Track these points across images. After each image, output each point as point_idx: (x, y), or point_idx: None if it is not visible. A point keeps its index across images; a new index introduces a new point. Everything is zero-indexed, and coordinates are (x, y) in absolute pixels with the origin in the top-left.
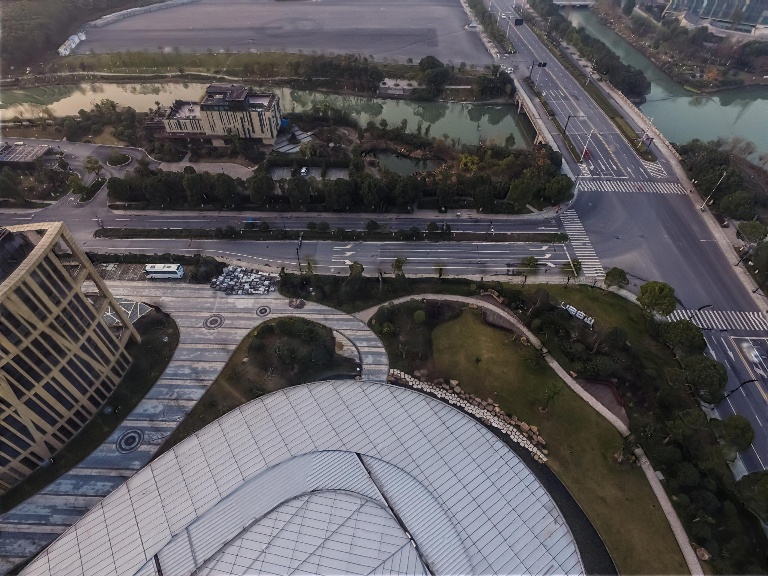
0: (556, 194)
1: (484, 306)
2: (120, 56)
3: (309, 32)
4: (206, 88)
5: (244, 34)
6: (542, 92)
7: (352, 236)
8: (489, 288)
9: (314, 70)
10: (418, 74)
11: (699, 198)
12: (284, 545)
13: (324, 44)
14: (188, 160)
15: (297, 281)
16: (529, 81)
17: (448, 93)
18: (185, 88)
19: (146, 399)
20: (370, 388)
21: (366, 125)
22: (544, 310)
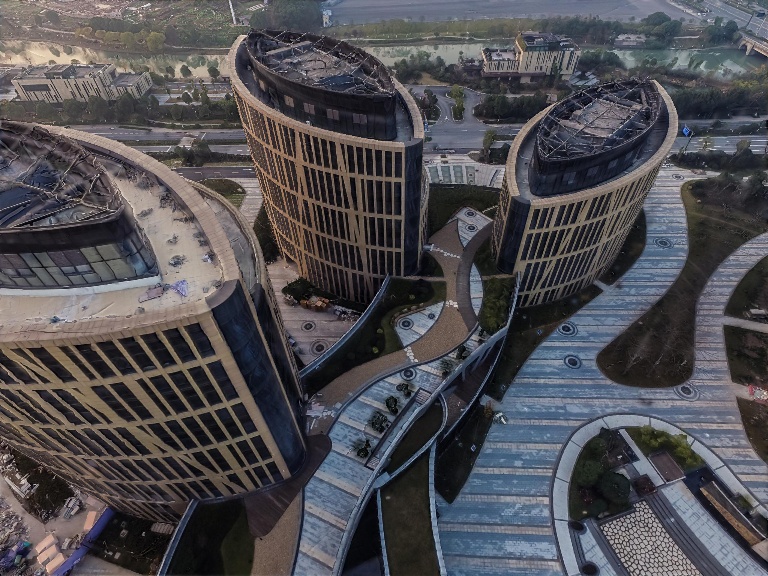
0: None
1: None
2: (384, 24)
3: (516, 3)
4: (520, 35)
5: (461, 7)
6: (764, 37)
7: (702, 132)
8: None
9: (561, 27)
10: (650, 27)
11: None
12: None
13: (539, 11)
14: (510, 93)
15: (695, 156)
16: (746, 30)
17: (677, 42)
18: (435, 50)
19: (649, 223)
20: None
21: (630, 66)
22: None
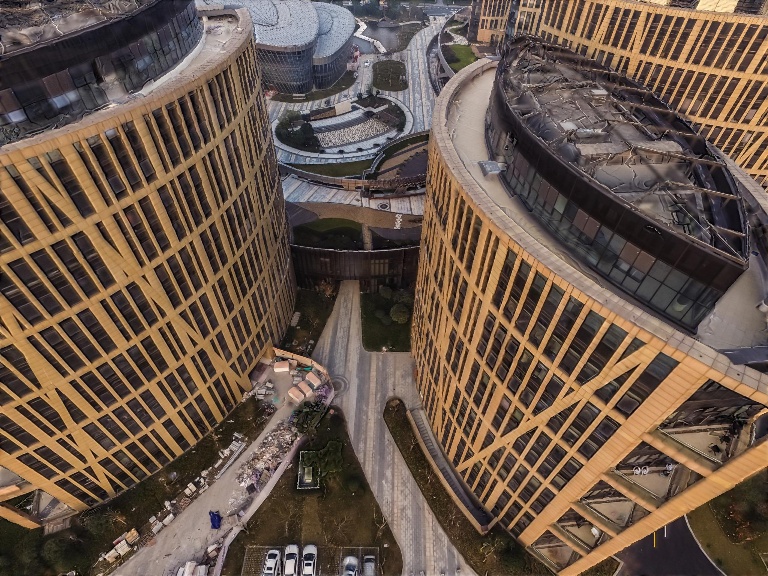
0: None
1: None
2: None
3: None
4: None
5: None
6: None
7: None
8: None
9: None
10: None
11: None
12: (217, 1)
13: None
14: None
15: None
16: None
17: None
18: None
19: None
20: None
21: None
22: None
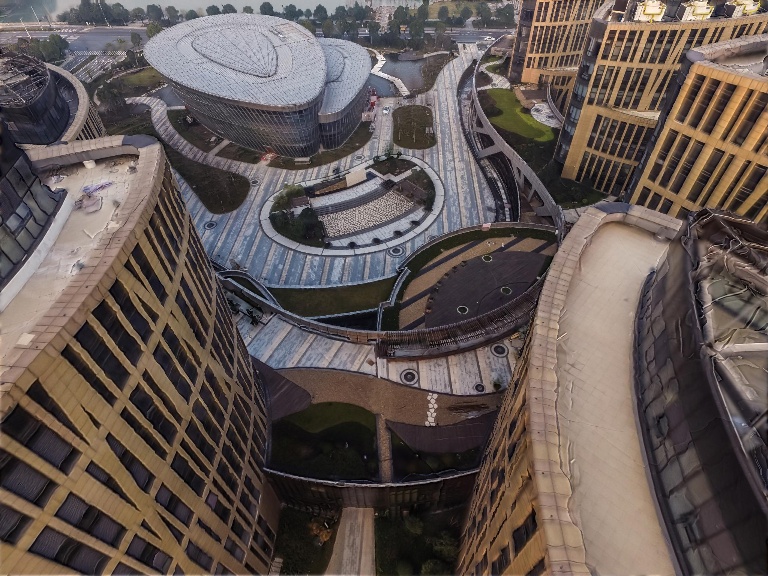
0: (61, 44)
1: (122, 74)
2: None
3: None
4: None
5: None
6: None
7: None
8: (112, 70)
9: None
10: None
11: (102, 26)
12: None
13: None
14: None
15: None
16: None
17: None
18: None
19: None
20: (158, 35)
21: None
22: (139, 57)
